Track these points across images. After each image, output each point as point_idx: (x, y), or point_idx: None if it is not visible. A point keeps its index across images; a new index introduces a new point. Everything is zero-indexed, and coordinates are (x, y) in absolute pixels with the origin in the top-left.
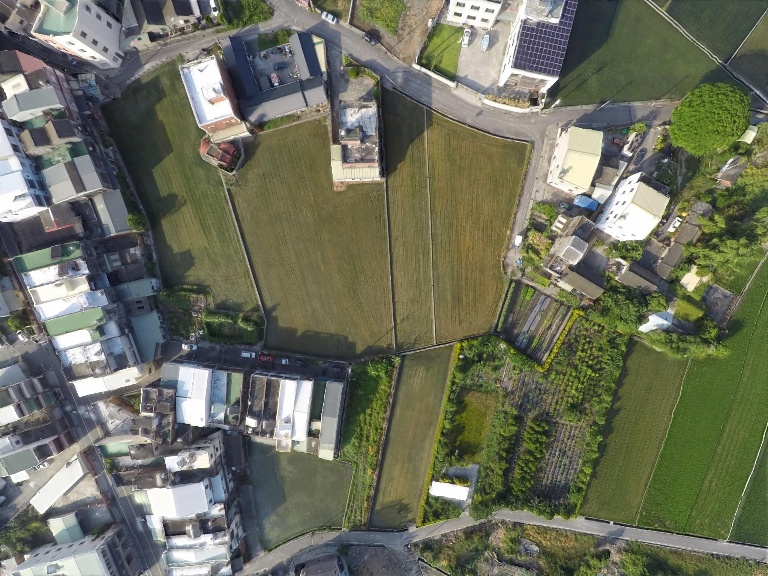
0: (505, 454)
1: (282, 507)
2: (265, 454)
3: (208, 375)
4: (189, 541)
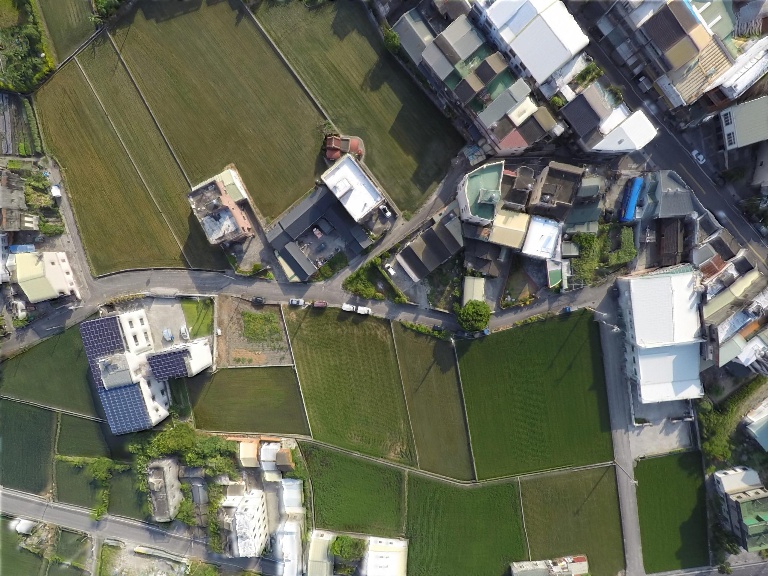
0: None
1: None
2: None
3: None
4: None
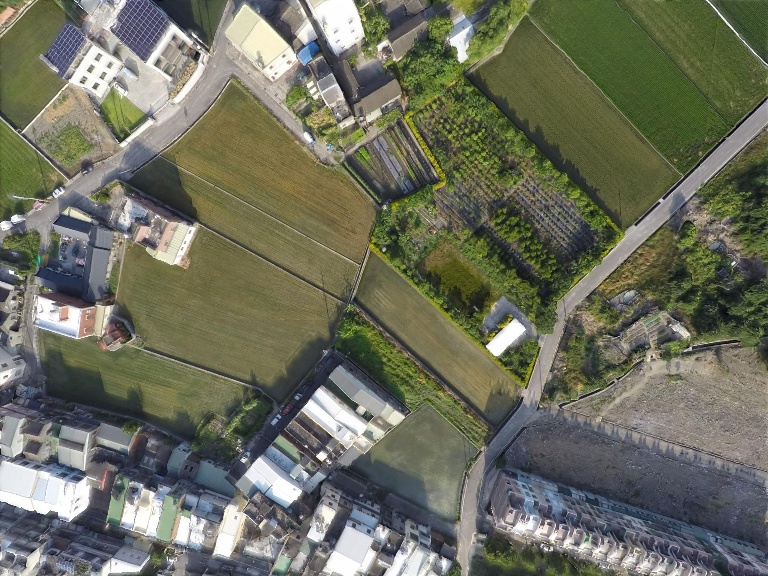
0: (503, 265)
1: (426, 483)
2: (370, 464)
3: (262, 460)
4: (395, 570)
